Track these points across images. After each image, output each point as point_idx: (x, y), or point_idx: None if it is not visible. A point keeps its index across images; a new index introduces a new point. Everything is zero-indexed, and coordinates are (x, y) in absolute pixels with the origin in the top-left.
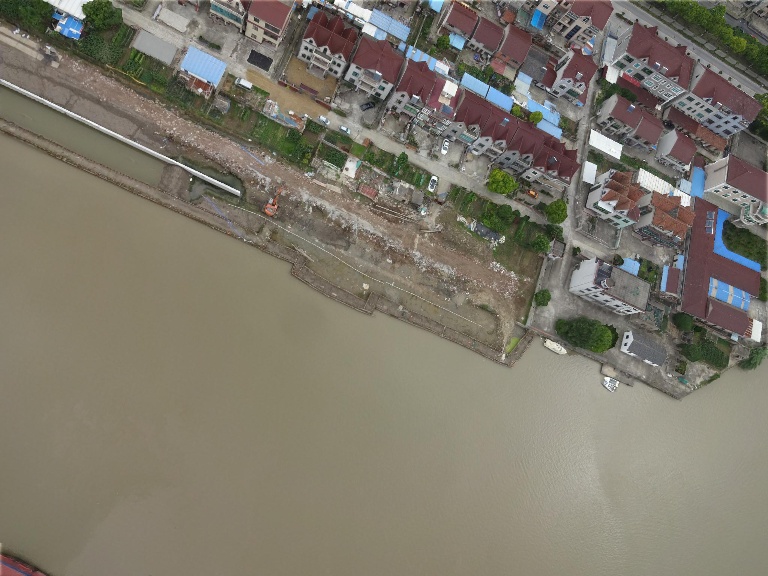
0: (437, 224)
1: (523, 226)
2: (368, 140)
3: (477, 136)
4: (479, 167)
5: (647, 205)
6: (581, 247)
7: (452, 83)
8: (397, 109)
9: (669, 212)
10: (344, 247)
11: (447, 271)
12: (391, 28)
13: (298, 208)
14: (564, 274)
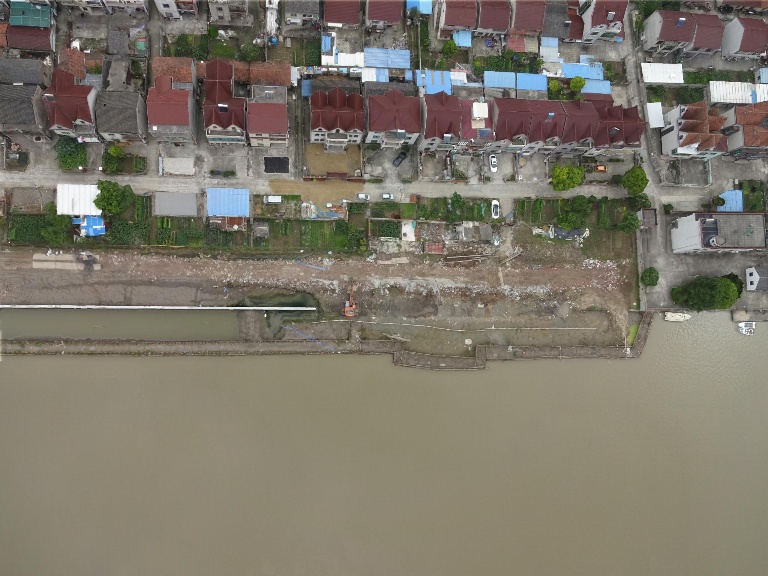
0: (514, 248)
1: (603, 208)
2: (414, 196)
3: (525, 143)
4: (535, 167)
5: (732, 125)
6: (671, 201)
7: (480, 103)
8: (430, 149)
9: (760, 124)
10: (433, 313)
11: (542, 291)
12: (390, 61)
13: (374, 295)
14: (662, 238)
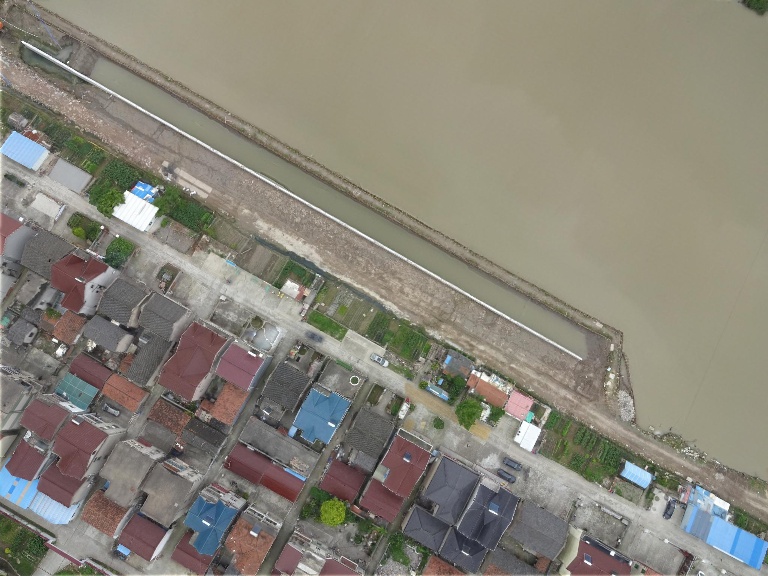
0: None
1: None
2: None
3: None
4: None
5: None
6: None
7: None
8: None
9: None
10: None
11: None
12: None
13: None
14: None
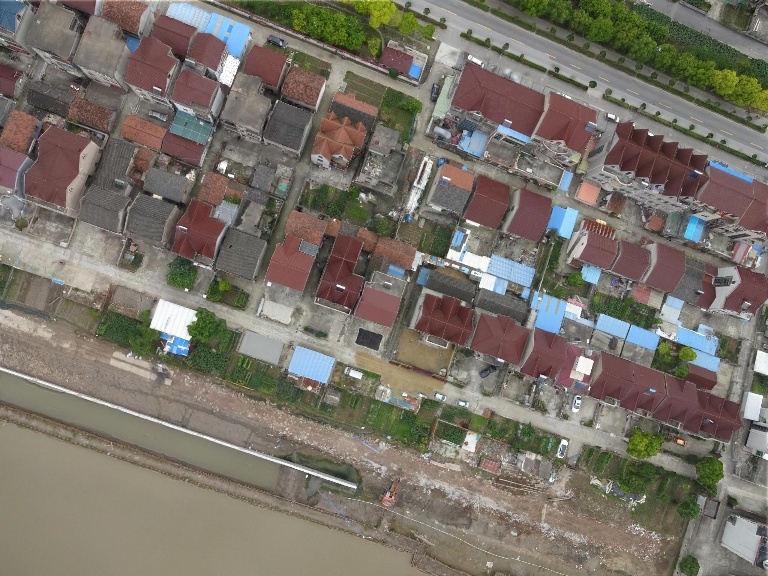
0: (567, 491)
1: None
2: (489, 413)
3: (615, 404)
4: (616, 419)
5: None
6: (738, 494)
7: (587, 359)
8: None
9: None
10: (465, 525)
11: (578, 540)
12: (513, 274)
13: (416, 491)
14: (716, 527)
